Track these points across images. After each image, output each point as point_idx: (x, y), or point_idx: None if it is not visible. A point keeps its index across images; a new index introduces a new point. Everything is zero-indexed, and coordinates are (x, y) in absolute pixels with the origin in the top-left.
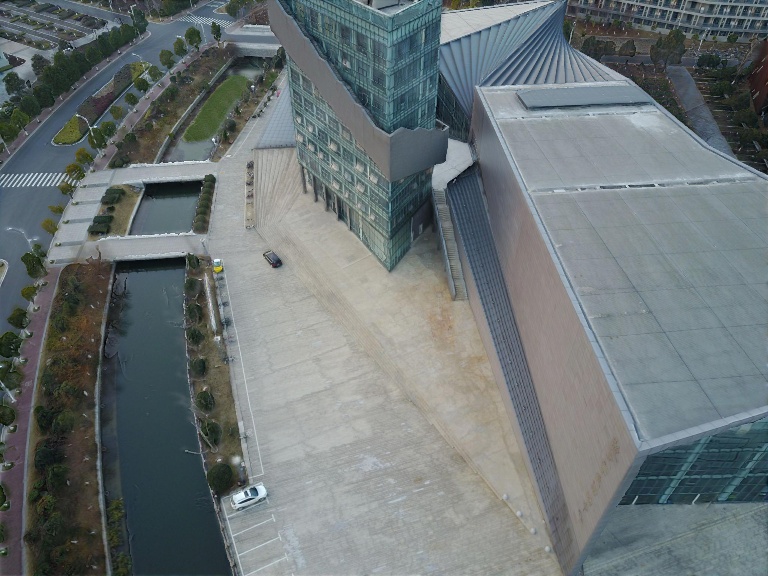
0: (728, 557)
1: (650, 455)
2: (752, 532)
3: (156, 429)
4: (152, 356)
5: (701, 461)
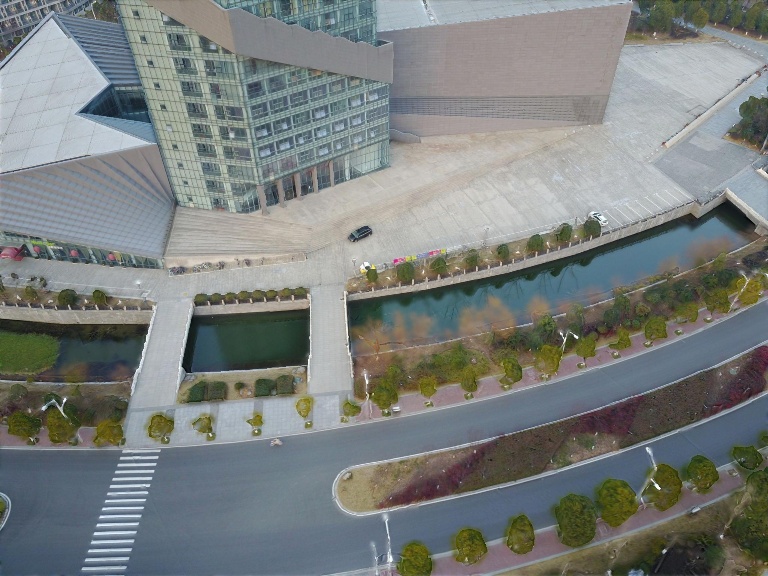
0: None
1: None
2: None
3: None
4: None
5: None
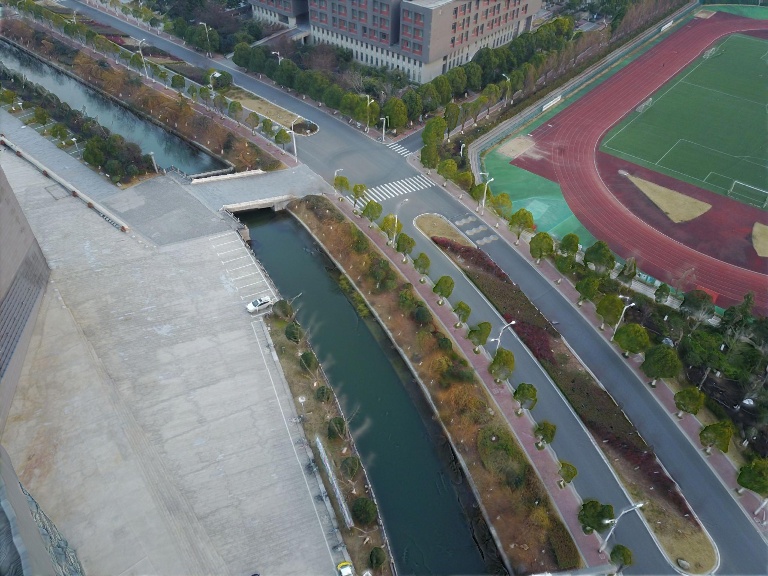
0: None
1: None
2: None
3: (368, 392)
4: (416, 493)
5: None
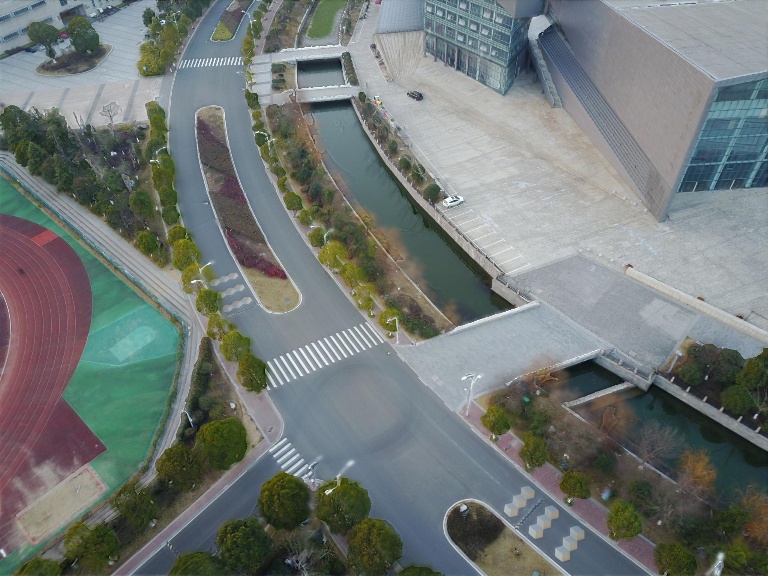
0: (754, 209)
1: (720, 88)
2: (767, 199)
3: (365, 191)
4: (339, 163)
5: (737, 146)
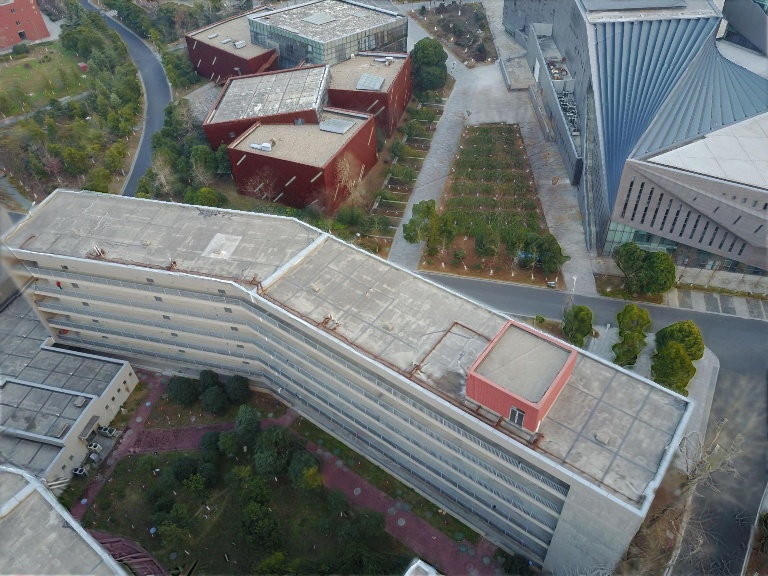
0: None
1: None
2: None
3: None
4: None
5: None
